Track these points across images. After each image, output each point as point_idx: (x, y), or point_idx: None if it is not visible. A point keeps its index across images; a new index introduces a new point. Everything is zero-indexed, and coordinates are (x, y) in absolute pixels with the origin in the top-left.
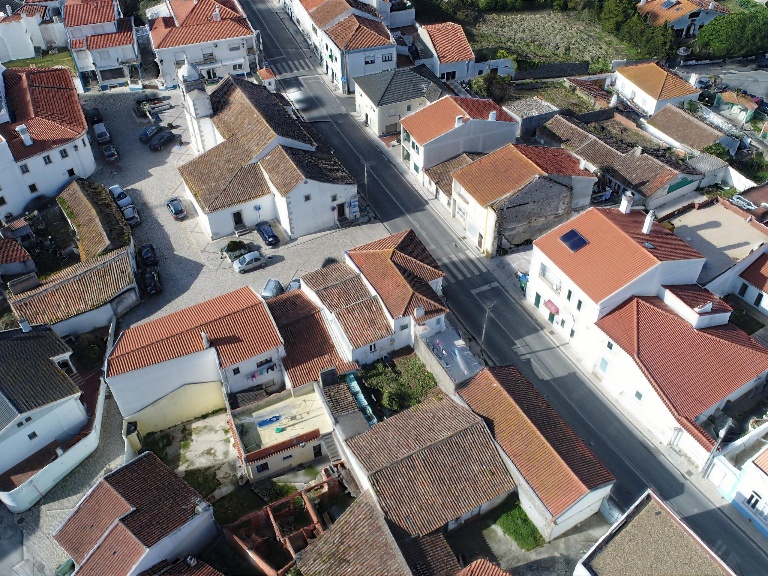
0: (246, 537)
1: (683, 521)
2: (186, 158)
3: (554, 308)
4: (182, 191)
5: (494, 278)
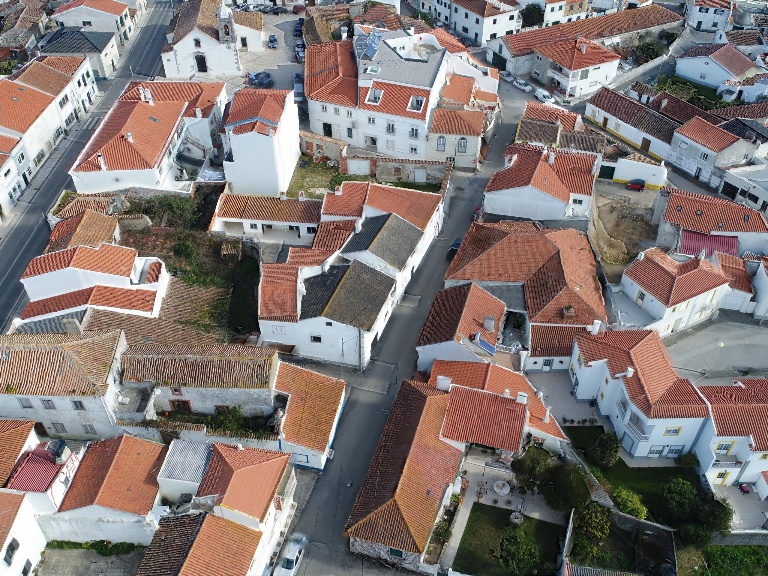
0: None
1: None
2: (251, 67)
3: None
4: (265, 52)
5: (156, 2)
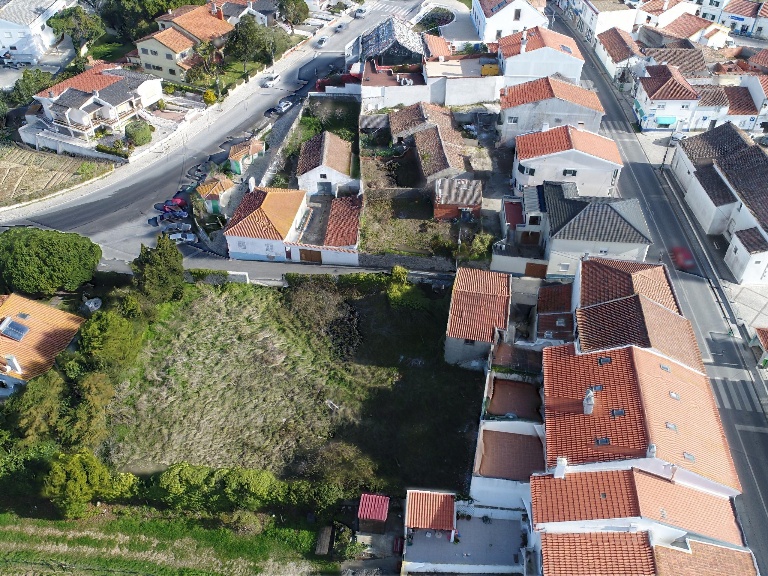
0: None
1: None
2: None
3: None
4: None
5: None
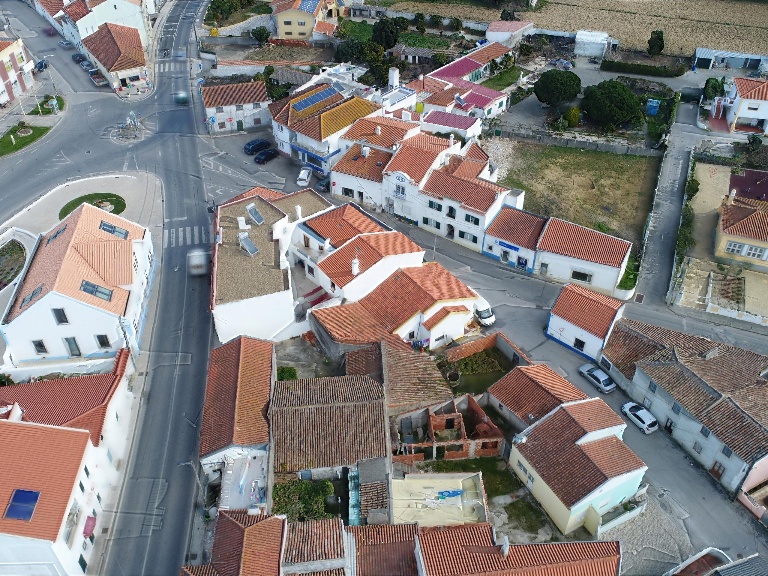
0: (488, 432)
1: (181, 351)
2: None
3: (91, 521)
4: None
5: None
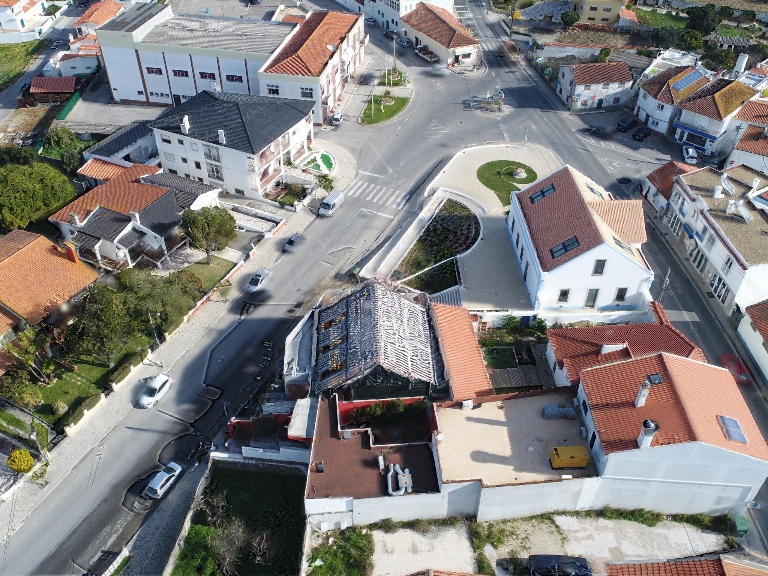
0: None
1: (683, 309)
2: None
3: None
4: None
5: None
